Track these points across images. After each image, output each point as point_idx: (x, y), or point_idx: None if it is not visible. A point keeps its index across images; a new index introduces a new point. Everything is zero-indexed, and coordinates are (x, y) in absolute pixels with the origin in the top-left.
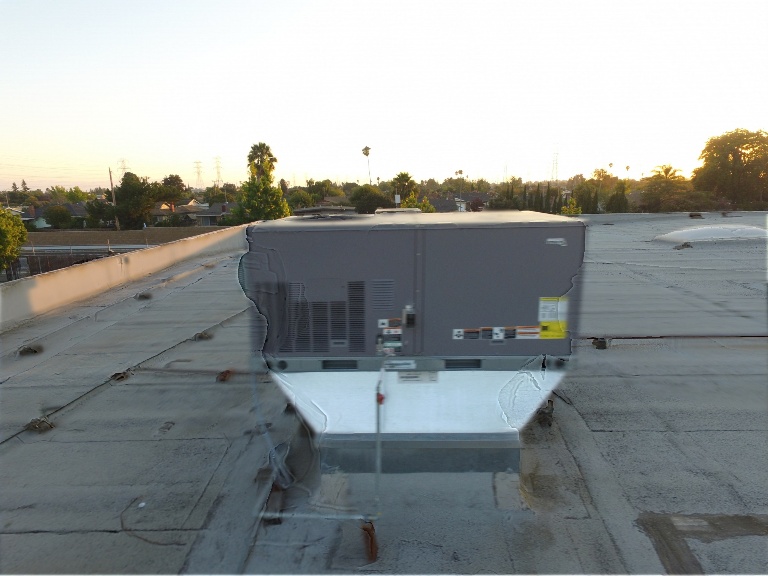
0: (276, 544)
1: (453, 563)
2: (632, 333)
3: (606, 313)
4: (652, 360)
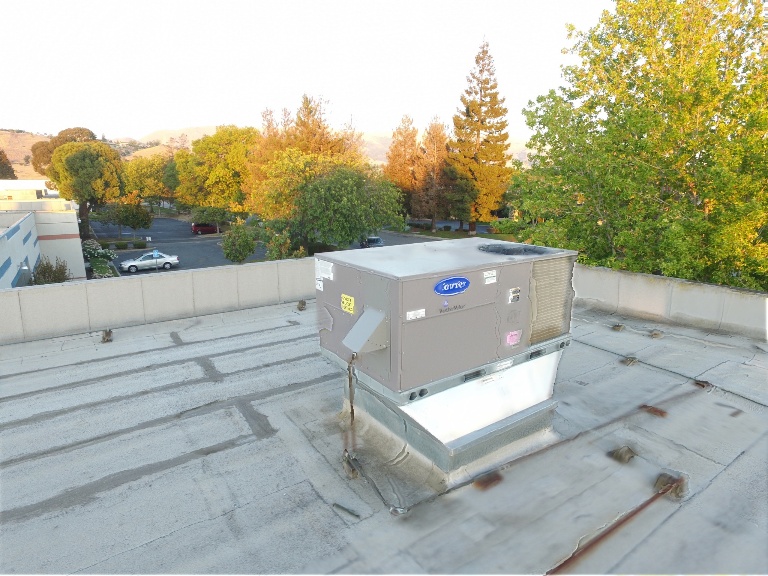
0: None
1: None
2: None
3: None
4: None
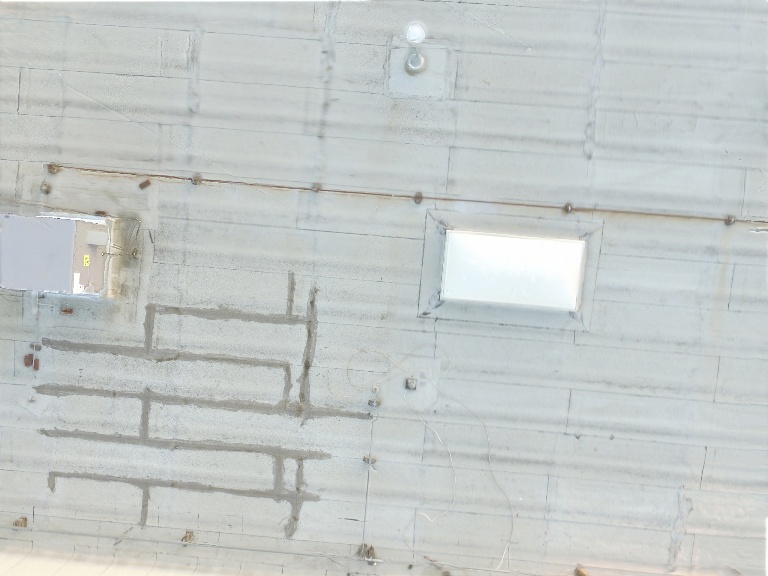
0: (45, 305)
1: (92, 315)
2: (227, 161)
3: (233, 119)
4: (213, 203)
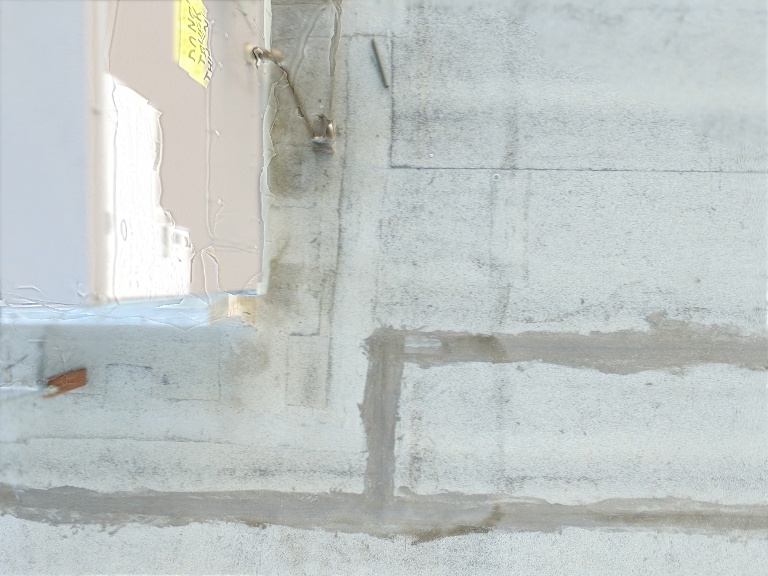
0: None
1: (162, 387)
2: None
3: None
4: None
